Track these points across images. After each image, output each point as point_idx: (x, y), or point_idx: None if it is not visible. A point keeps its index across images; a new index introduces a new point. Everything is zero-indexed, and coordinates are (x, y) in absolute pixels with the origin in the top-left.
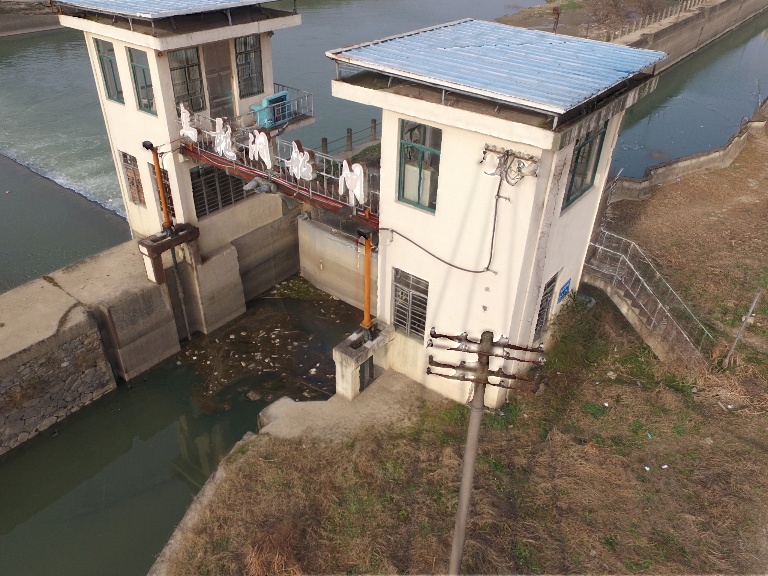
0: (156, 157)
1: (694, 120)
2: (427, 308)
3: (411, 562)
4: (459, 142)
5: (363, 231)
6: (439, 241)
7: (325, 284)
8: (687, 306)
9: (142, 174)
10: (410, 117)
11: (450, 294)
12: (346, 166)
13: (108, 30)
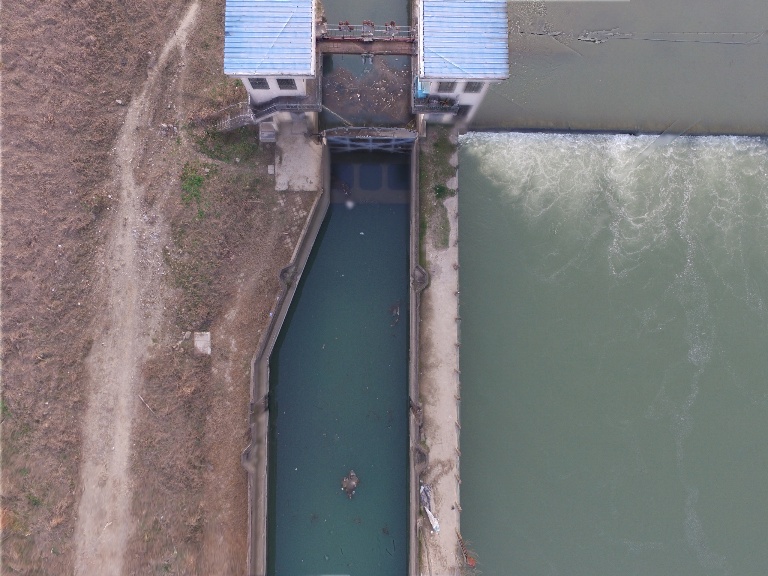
0: None
1: None
2: None
3: None
4: None
5: None
6: None
7: None
8: (231, 170)
9: None
10: None
11: None
12: None
13: None
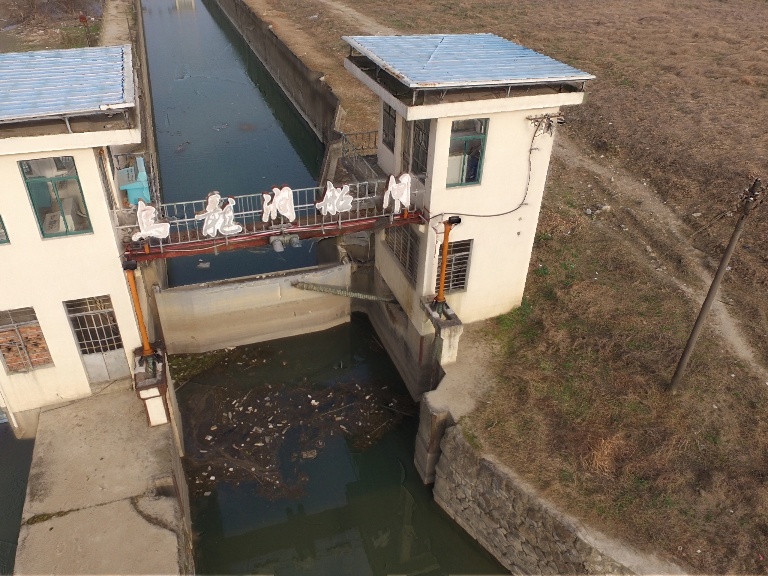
0: (132, 277)
1: (226, 92)
2: (471, 260)
3: (624, 389)
4: (503, 122)
5: (457, 218)
6: (484, 203)
7: (212, 343)
8: None
9: (47, 323)
10: (464, 117)
11: (492, 238)
12: (393, 180)
13: (12, 145)
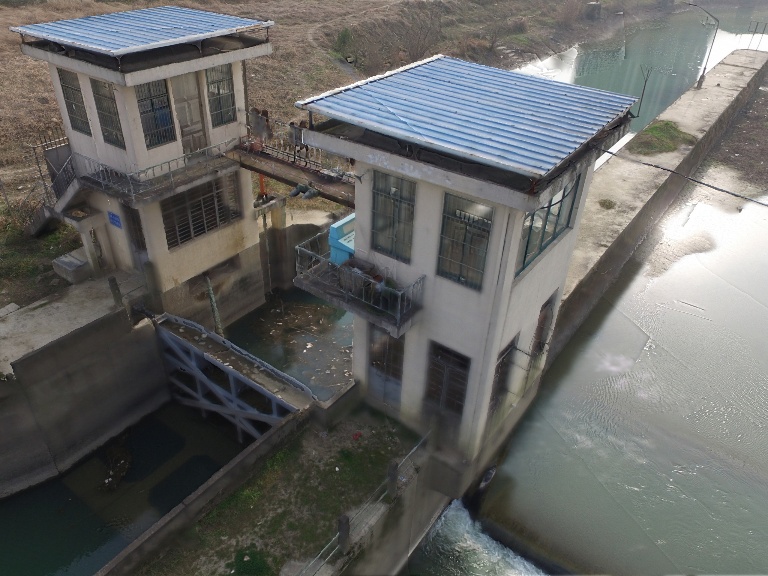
0: None
1: None
2: None
3: None
4: None
5: None
6: None
7: None
8: None
9: None
10: None
11: None
12: None
13: None
